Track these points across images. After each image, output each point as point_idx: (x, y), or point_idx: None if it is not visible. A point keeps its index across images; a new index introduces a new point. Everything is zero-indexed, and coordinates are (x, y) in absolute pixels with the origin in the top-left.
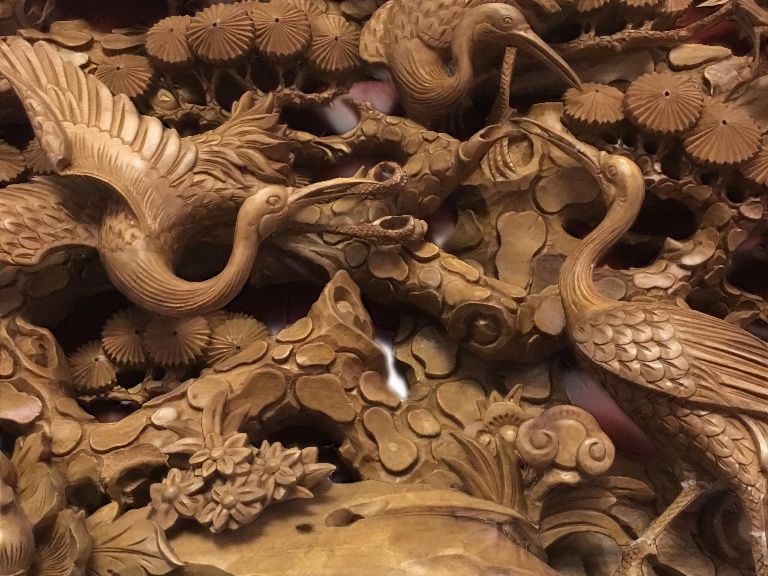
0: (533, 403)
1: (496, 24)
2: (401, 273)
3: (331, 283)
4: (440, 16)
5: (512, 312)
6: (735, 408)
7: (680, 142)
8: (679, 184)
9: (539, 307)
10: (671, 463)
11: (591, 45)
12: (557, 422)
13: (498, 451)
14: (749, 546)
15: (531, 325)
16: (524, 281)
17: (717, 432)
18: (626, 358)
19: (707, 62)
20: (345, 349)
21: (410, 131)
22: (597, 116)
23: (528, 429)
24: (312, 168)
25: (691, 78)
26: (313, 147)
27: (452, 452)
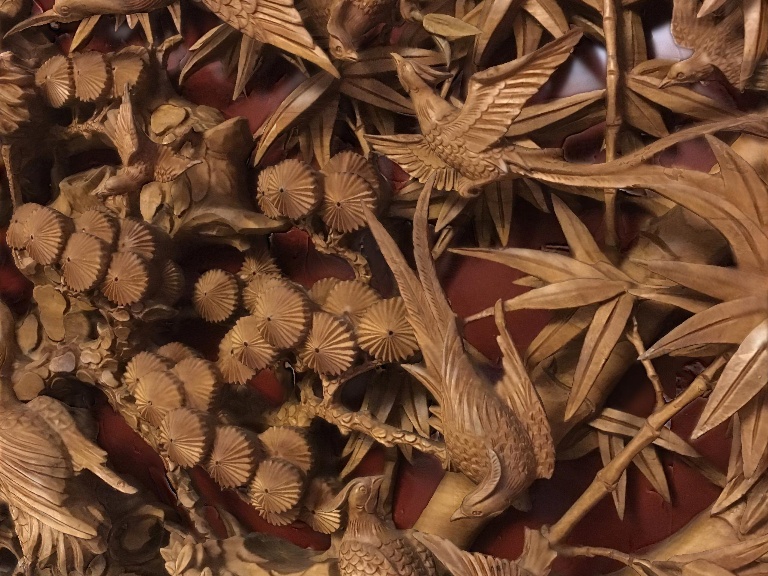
0: None
1: None
2: None
3: None
4: None
5: None
6: (16, 507)
7: None
8: None
9: (18, 382)
10: None
11: (76, 132)
12: None
13: None
14: (134, 551)
15: None
16: (62, 333)
17: (14, 519)
18: None
19: (168, 129)
20: None
21: None
22: (16, 244)
23: None
24: None
25: None
26: None
27: None
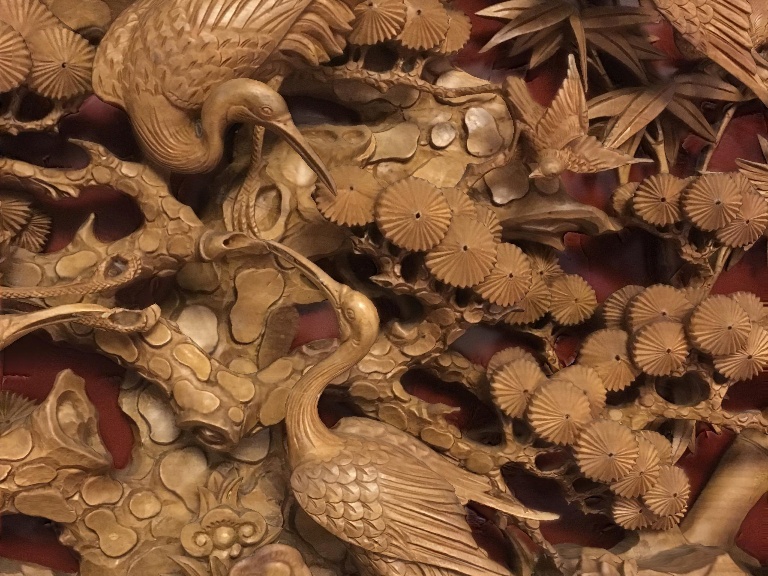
0: (251, 464)
1: (254, 110)
2: (130, 355)
3: (53, 395)
4: (191, 76)
5: (238, 424)
6: None
7: (422, 253)
8: (414, 290)
9: (266, 400)
10: (360, 569)
11: (357, 78)
12: (266, 566)
13: (211, 572)
14: None
15: (256, 421)
16: (257, 332)
17: None
18: (334, 516)
19: (471, 101)
20: (67, 466)
21: (148, 190)
22: (347, 218)
23: (240, 571)
24: (32, 194)
25: (452, 119)
26: (33, 183)
27: (171, 527)
